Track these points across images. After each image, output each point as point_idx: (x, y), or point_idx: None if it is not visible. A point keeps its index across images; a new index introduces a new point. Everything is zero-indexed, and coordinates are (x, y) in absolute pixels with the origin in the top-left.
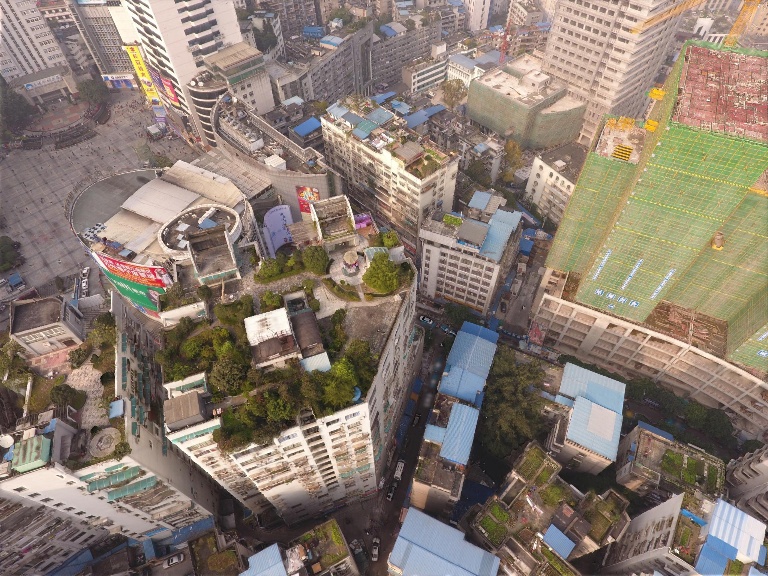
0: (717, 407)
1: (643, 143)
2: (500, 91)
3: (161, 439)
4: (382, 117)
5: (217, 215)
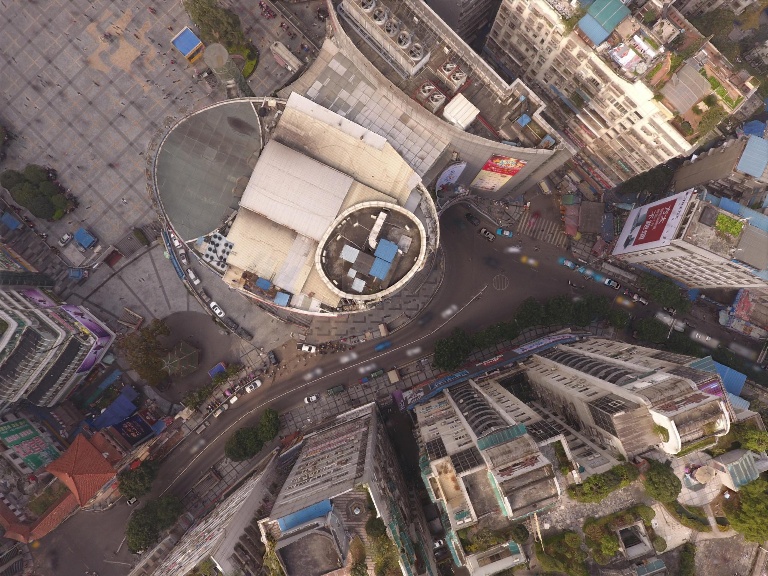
0: None
1: None
2: None
3: (429, 575)
4: None
5: (387, 220)
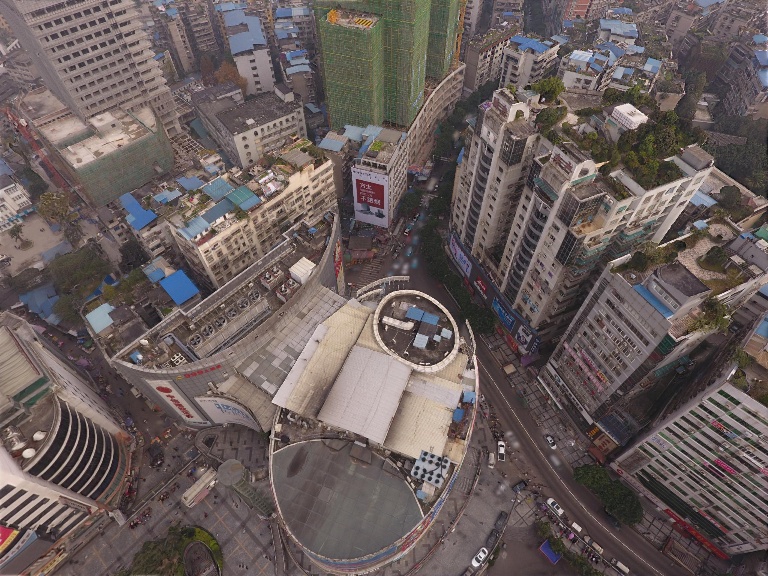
0: (445, 111)
1: (353, 15)
2: (110, 151)
3: None
4: (221, 187)
5: None
